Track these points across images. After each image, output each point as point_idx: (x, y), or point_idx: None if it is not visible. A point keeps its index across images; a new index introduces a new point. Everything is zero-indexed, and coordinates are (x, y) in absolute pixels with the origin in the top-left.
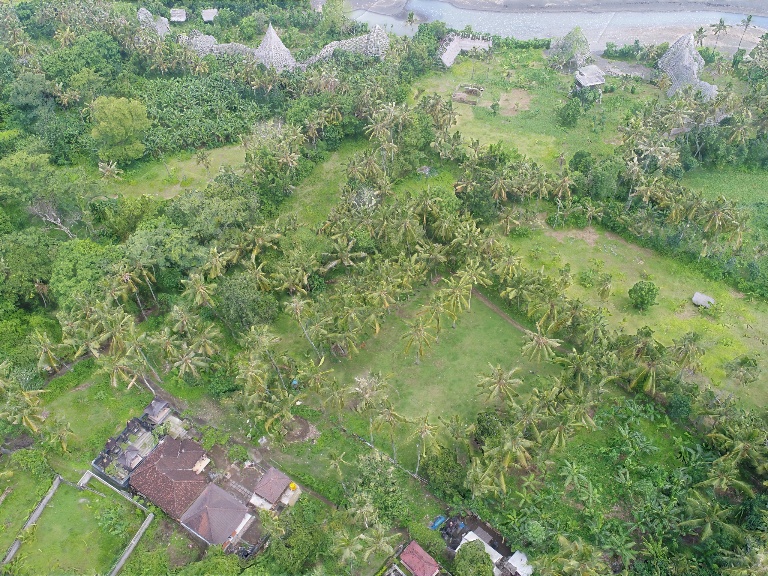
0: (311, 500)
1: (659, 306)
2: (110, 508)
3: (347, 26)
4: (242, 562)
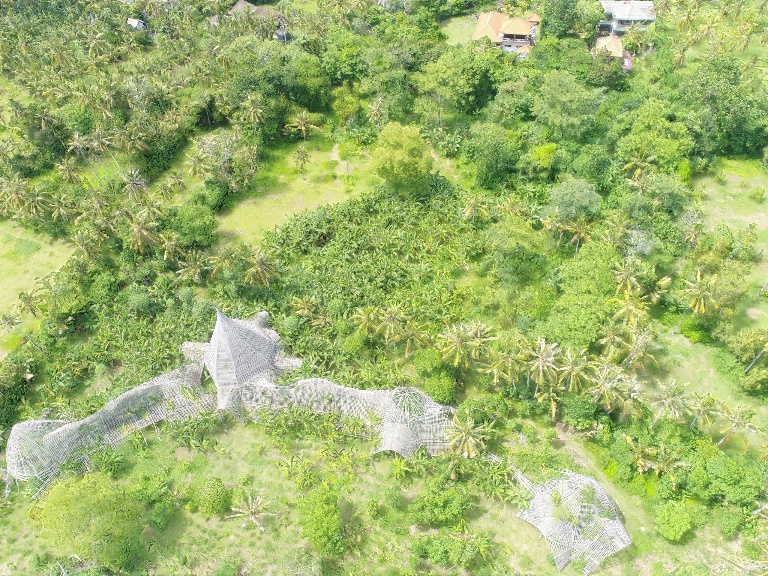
0: None
1: None
2: (287, 4)
3: (80, 568)
4: (228, 2)
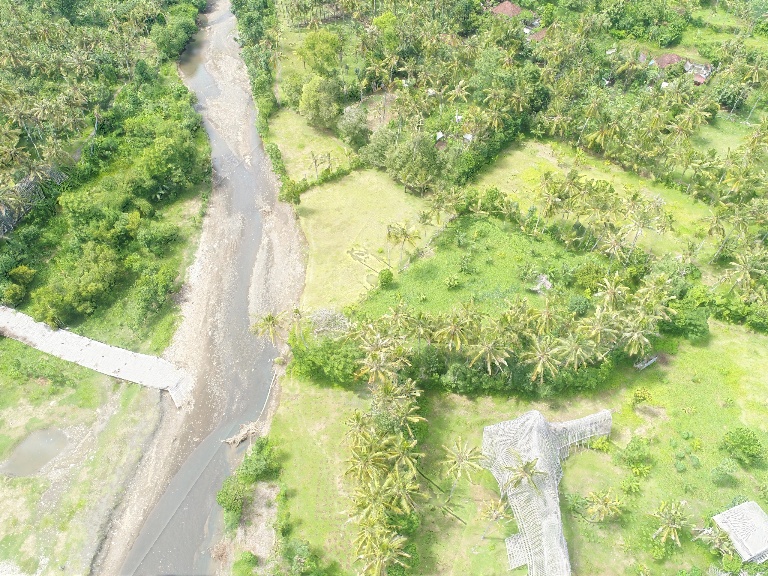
0: (760, 101)
1: None
2: None
3: None
4: None
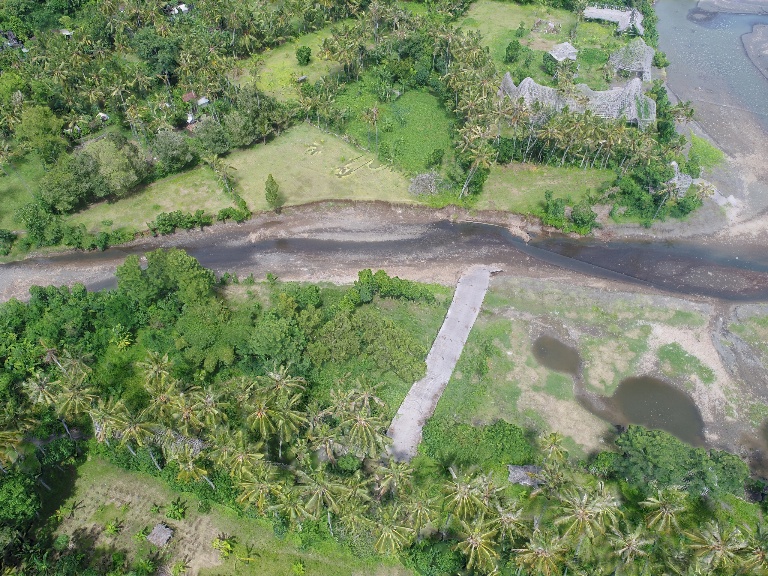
0: None
1: None
2: None
3: None
4: None
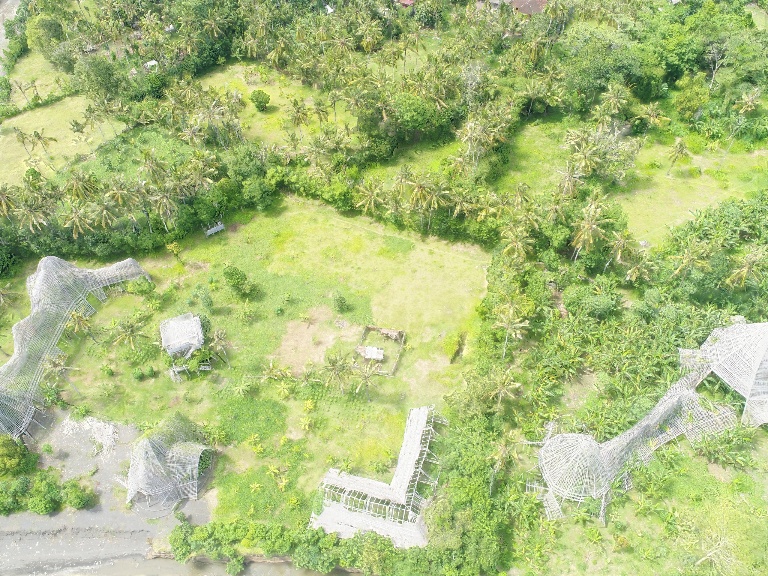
0: None
1: (248, 111)
2: None
3: None
4: None
